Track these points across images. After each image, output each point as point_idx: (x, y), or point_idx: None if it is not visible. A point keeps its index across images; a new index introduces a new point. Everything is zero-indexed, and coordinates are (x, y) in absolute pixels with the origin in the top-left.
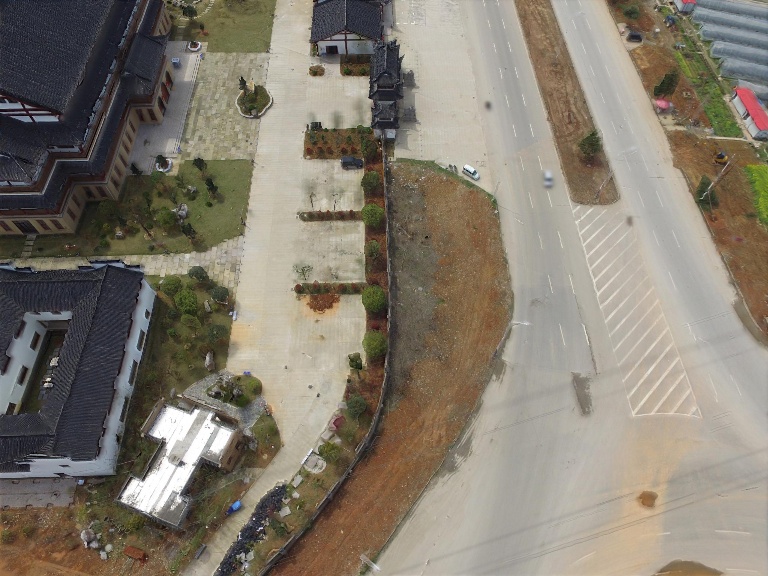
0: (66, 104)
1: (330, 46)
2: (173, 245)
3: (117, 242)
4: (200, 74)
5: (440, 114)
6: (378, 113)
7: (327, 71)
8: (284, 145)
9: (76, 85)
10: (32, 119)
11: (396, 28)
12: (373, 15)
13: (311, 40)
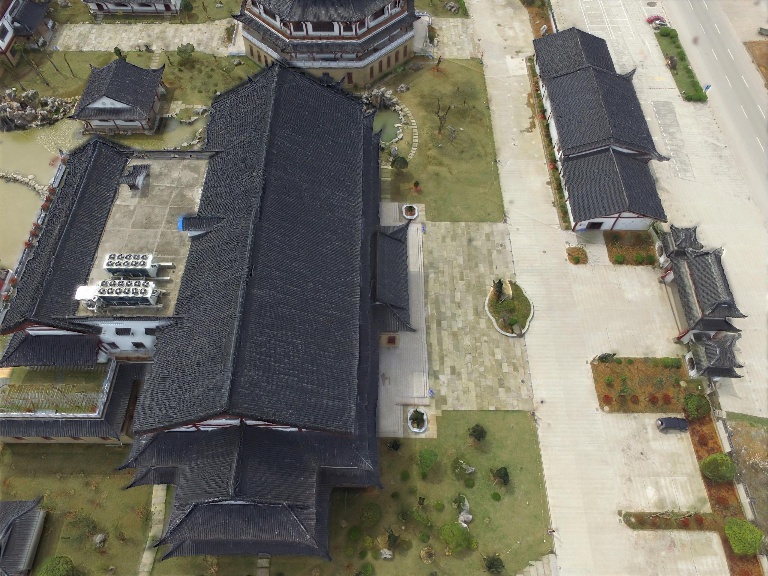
0: (354, 414)
1: (594, 222)
2: (462, 571)
3: (384, 564)
4: (427, 258)
5: (761, 334)
6: (715, 360)
7: (591, 256)
8: (568, 385)
9: (356, 372)
10: (299, 428)
11: (659, 185)
12: (645, 178)
13: (574, 218)
